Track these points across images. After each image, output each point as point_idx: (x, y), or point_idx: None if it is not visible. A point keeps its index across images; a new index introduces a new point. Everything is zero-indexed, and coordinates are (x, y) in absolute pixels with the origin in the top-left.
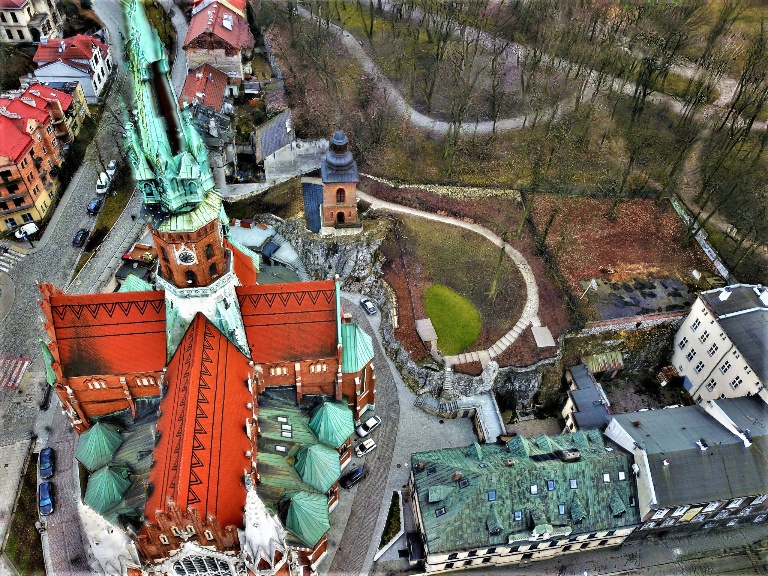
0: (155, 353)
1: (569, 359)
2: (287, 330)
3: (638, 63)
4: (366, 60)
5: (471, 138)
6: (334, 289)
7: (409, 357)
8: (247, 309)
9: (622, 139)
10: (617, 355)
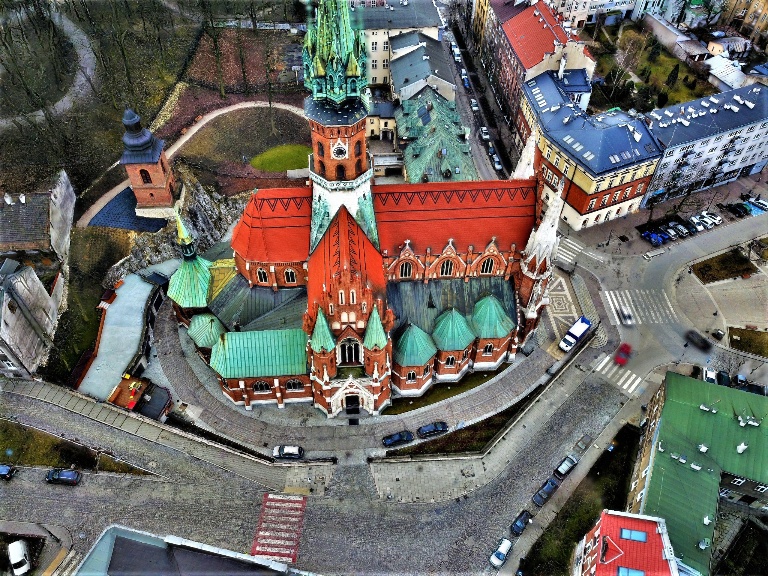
0: (373, 253)
1: None
2: None
3: None
4: None
5: (100, 86)
6: None
7: None
8: None
9: (137, 18)
10: None
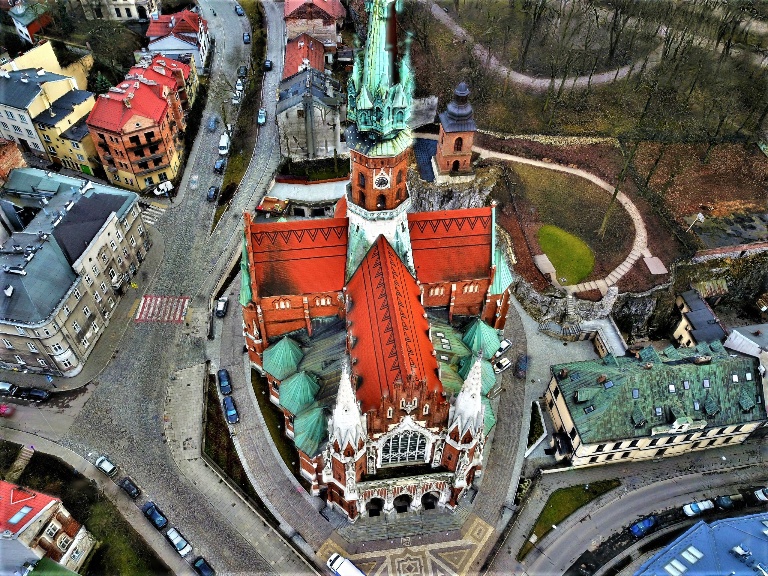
0: (335, 275)
1: (679, 286)
2: (448, 253)
3: (732, 13)
4: (454, 25)
5: (567, 92)
6: (490, 215)
7: (531, 288)
8: (415, 234)
9: (707, 89)
10: (722, 282)
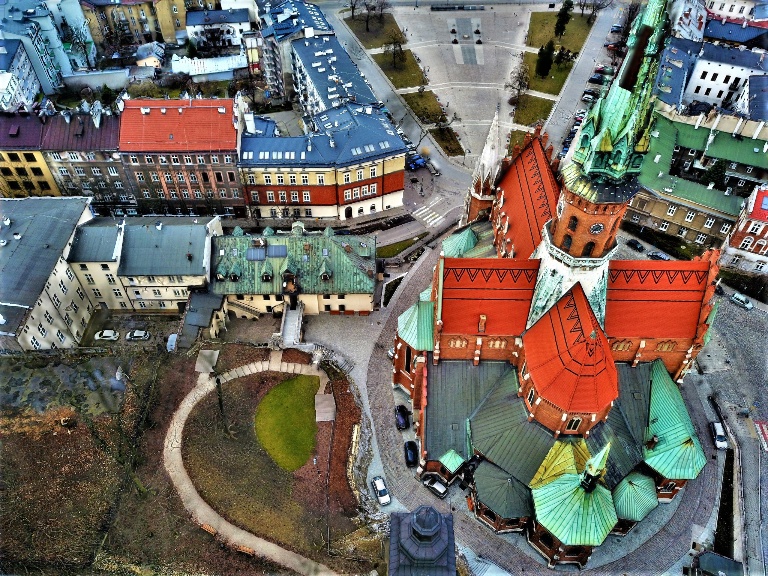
0: None
1: None
2: None
3: None
4: None
5: None
6: None
7: None
8: None
9: None
10: None
